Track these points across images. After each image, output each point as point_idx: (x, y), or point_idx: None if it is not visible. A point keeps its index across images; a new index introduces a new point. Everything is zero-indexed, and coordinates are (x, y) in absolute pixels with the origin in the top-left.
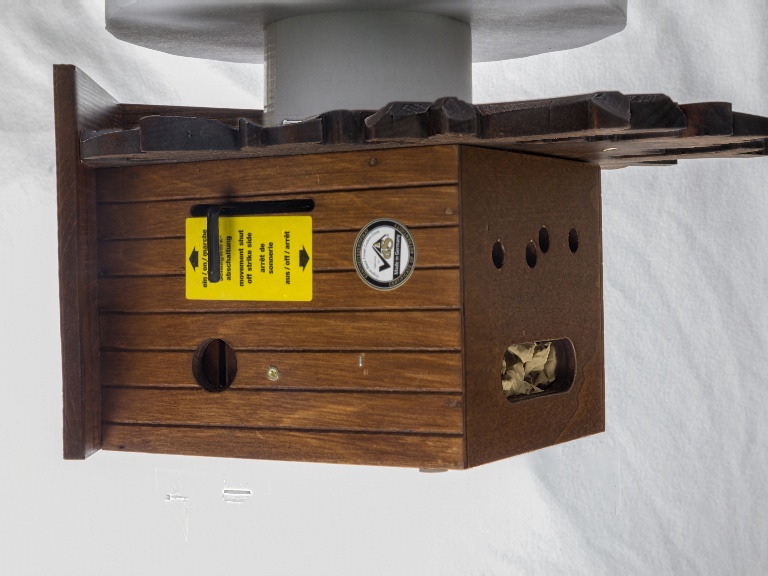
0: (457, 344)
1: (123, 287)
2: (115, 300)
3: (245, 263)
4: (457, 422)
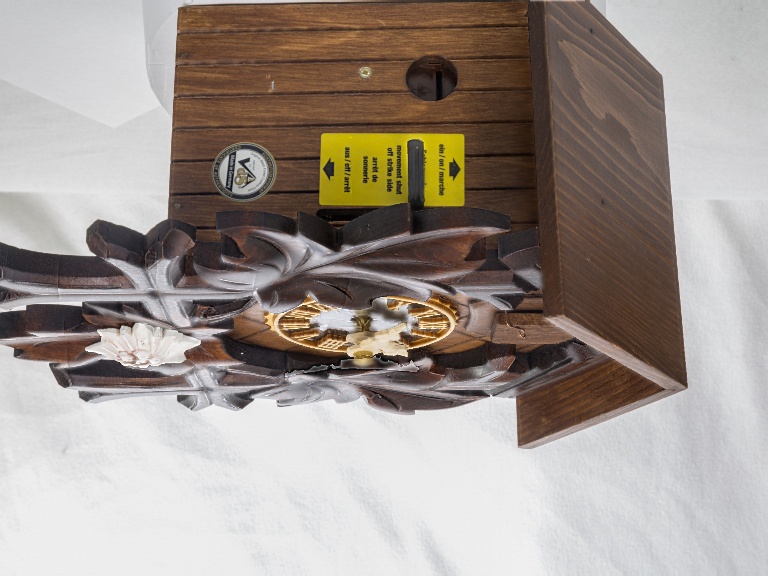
0: (177, 101)
1: None
2: None
3: (395, 165)
4: (181, 42)
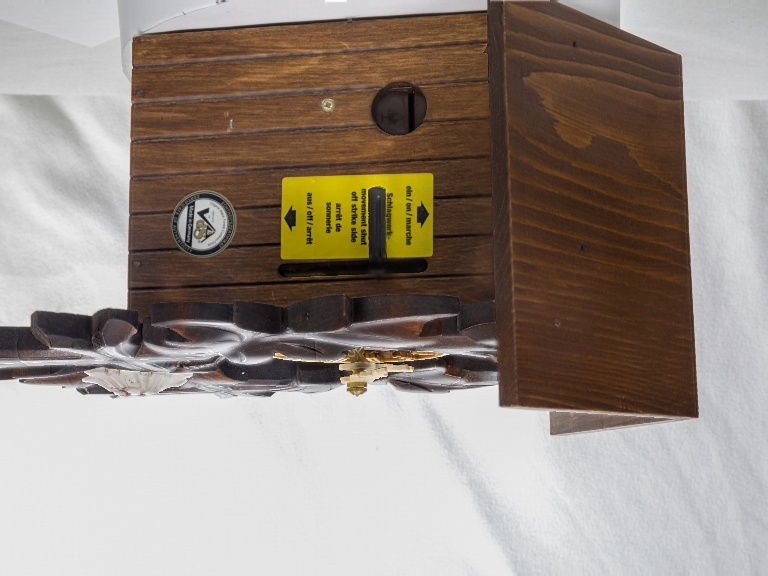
0: (134, 146)
1: None
2: None
3: (359, 212)
4: (136, 77)
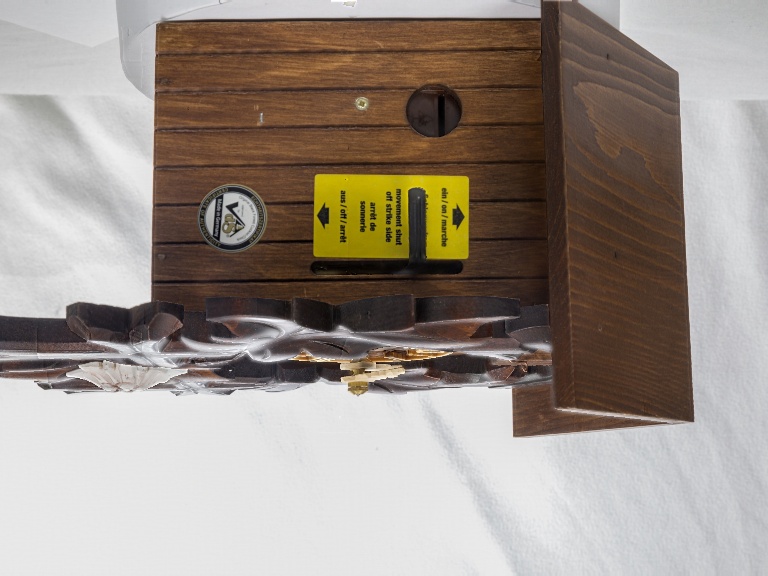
0: (158, 135)
1: None
2: None
3: (394, 212)
4: (160, 65)
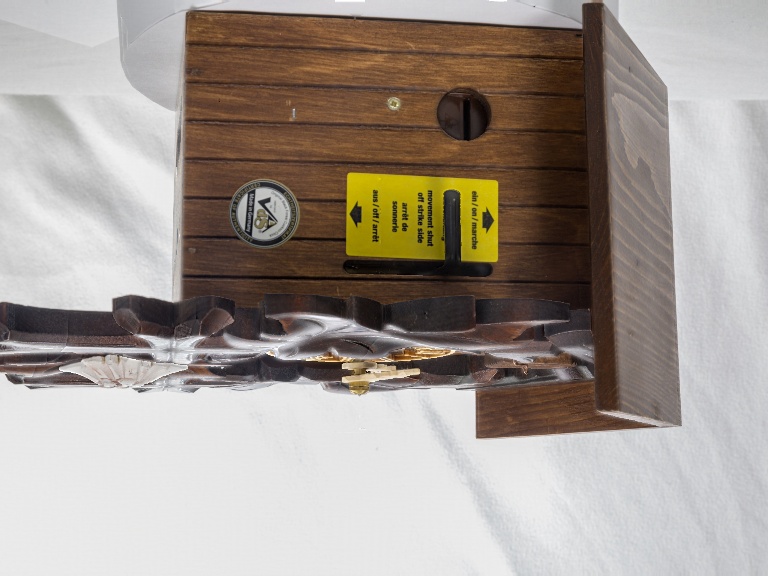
0: (188, 126)
1: (577, 196)
2: (587, 183)
3: (426, 213)
4: (191, 55)
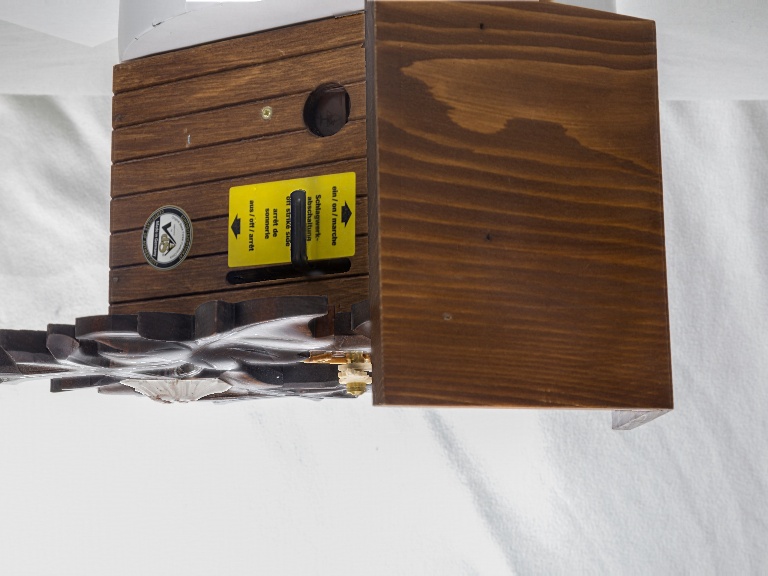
0: (113, 168)
1: None
2: None
3: None
4: (116, 103)
